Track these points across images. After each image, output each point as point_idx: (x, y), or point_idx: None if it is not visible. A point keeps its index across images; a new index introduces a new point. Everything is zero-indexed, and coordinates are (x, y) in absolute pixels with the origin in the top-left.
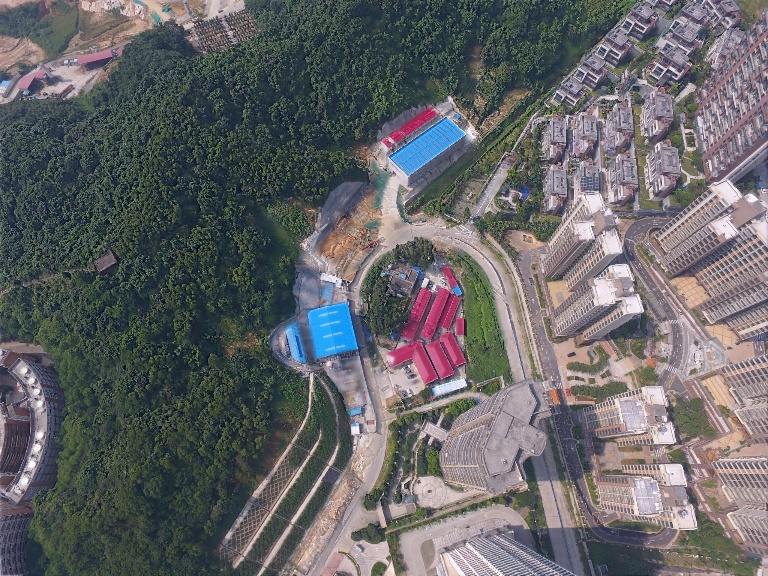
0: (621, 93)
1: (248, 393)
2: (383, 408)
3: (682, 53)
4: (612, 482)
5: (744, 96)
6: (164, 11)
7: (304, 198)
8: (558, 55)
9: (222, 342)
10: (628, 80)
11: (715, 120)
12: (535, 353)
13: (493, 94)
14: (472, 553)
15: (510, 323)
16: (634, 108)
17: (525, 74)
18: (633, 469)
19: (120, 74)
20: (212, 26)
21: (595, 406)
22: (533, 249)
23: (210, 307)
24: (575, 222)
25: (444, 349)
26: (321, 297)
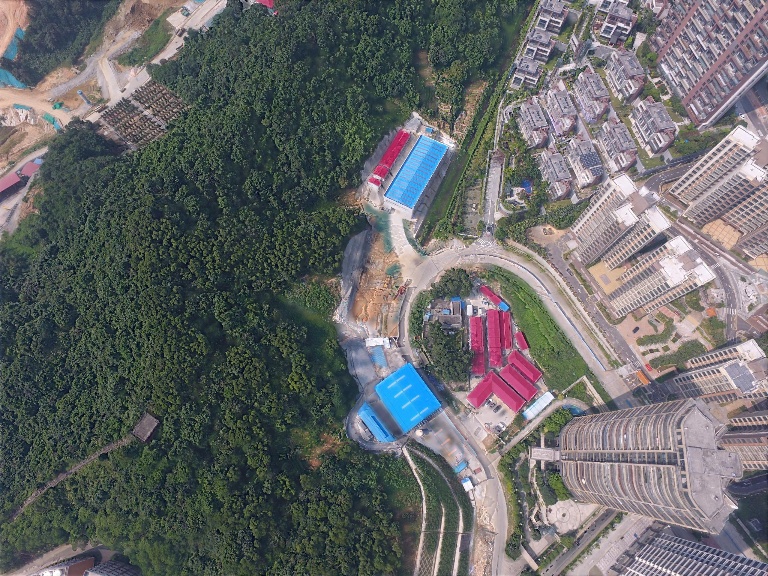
0: (577, 60)
1: (360, 502)
2: (483, 451)
3: (625, 7)
4: (738, 443)
5: (712, 38)
6: (56, 108)
7: (322, 271)
8: (502, 38)
9: (300, 455)
10: (582, 46)
11: (684, 65)
12: (602, 341)
13: (454, 96)
14: (660, 572)
15: (568, 320)
16: (597, 72)
17: (478, 67)
18: (746, 421)
19: (51, 202)
20: (122, 110)
21: (691, 376)
22: (557, 240)
23: (280, 428)
24: (615, 210)
25: (516, 370)
26: (375, 364)
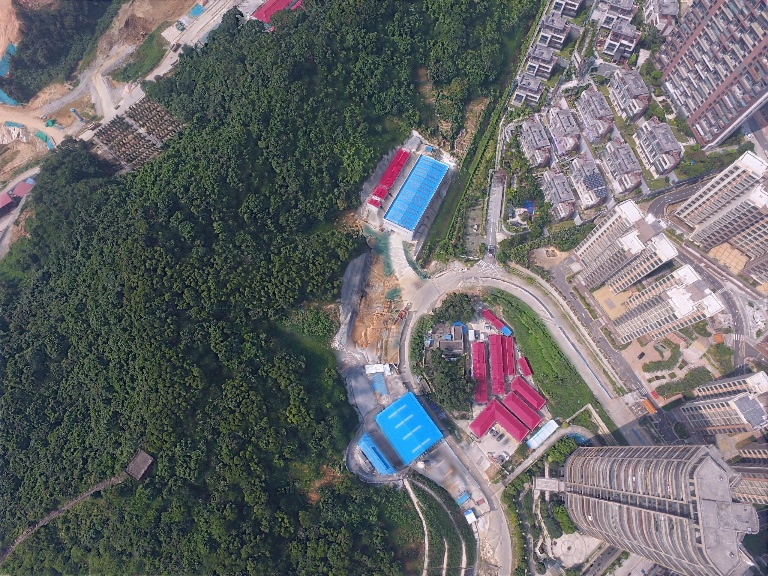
0: (580, 77)
1: (361, 539)
2: (486, 482)
3: (628, 24)
4: (748, 477)
5: (719, 58)
6: (48, 126)
7: (320, 298)
8: (502, 55)
9: (299, 489)
10: (585, 64)
11: (689, 84)
12: (607, 367)
13: (454, 114)
14: None
15: (572, 346)
16: (600, 90)
17: (479, 84)
18: (756, 454)
19: (43, 227)
20: (116, 128)
21: (699, 407)
22: (560, 262)
23: (278, 463)
24: (620, 237)
25: (520, 397)
26: (376, 392)
